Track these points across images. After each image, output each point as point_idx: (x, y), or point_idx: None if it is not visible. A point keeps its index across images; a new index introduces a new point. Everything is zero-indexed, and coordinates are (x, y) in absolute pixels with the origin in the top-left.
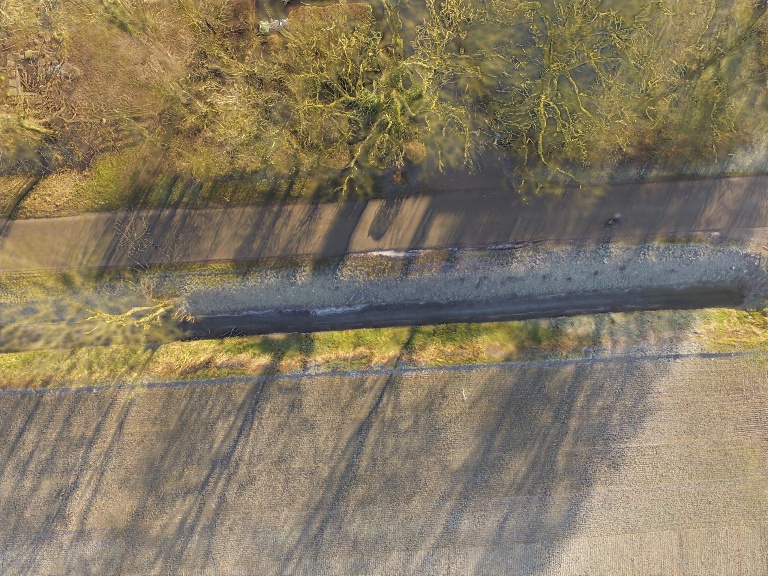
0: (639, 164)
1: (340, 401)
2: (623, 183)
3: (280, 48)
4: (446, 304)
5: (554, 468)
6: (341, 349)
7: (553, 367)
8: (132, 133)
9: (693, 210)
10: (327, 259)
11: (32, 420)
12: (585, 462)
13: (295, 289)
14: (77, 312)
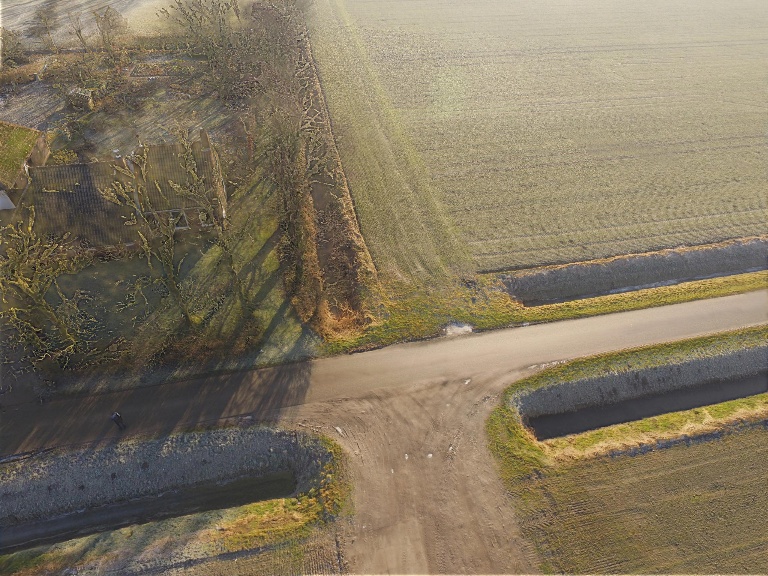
0: (173, 368)
1: None
2: (155, 385)
3: None
4: None
5: None
6: None
7: None
8: None
9: (224, 399)
10: None
11: None
12: None
13: None
14: None
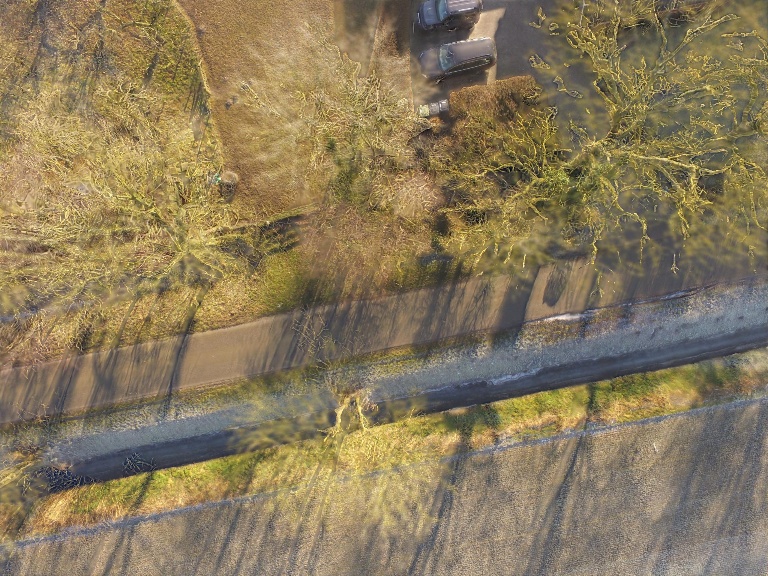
0: None
1: (535, 469)
2: None
3: (442, 130)
4: (619, 357)
5: (751, 507)
6: (526, 417)
7: (739, 408)
8: (298, 232)
9: None
10: (505, 331)
11: (234, 529)
12: None
13: (475, 364)
14: (261, 415)
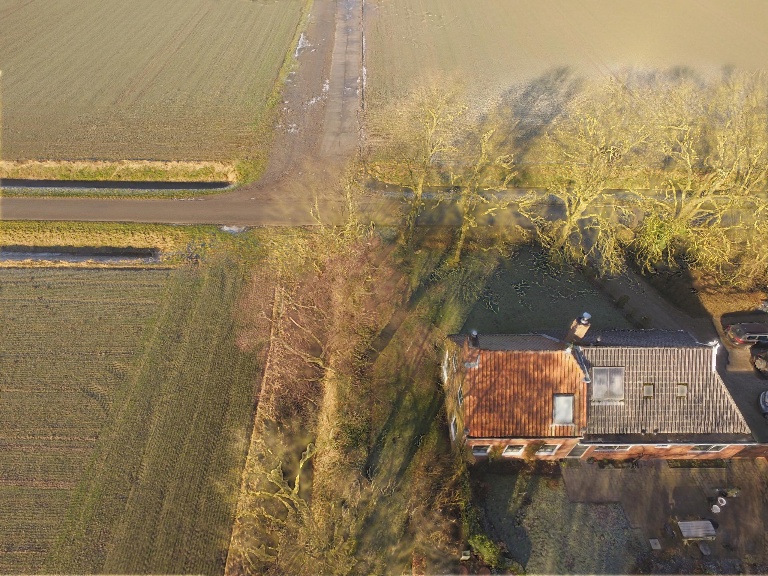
0: None
1: None
2: None
3: None
4: None
5: None
6: None
7: None
8: None
9: None
10: None
11: None
12: (477, 132)
13: None
14: None
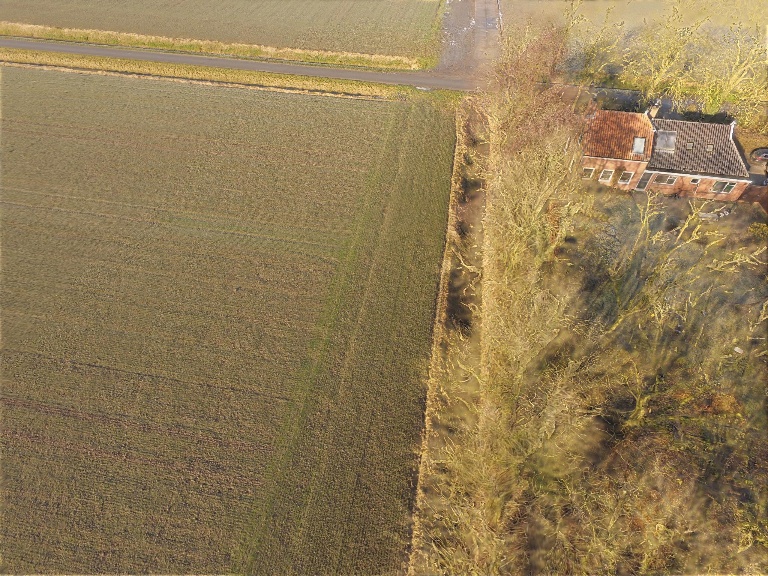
0: None
1: None
2: None
3: None
4: None
5: (600, 54)
6: None
7: None
8: None
9: None
10: None
11: None
12: None
13: None
14: None
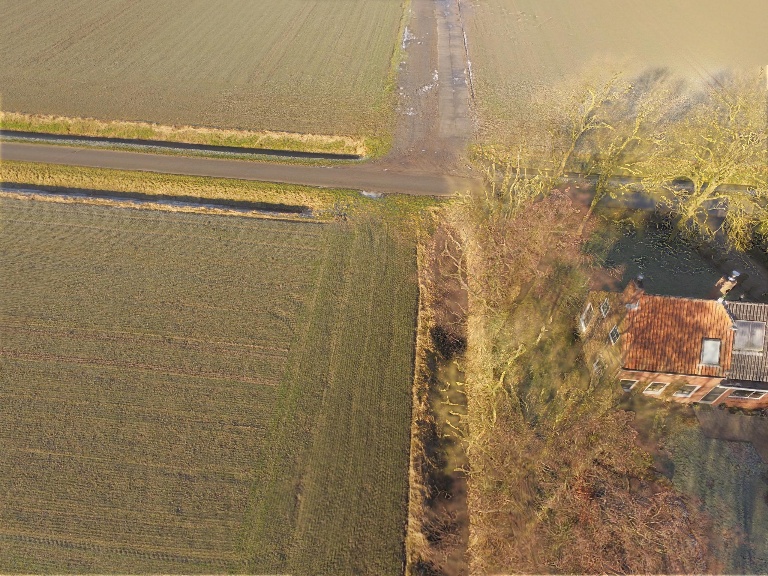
0: None
1: None
2: None
3: None
4: None
5: None
6: None
7: None
8: None
9: None
10: (764, 200)
11: None
12: None
13: None
14: None
